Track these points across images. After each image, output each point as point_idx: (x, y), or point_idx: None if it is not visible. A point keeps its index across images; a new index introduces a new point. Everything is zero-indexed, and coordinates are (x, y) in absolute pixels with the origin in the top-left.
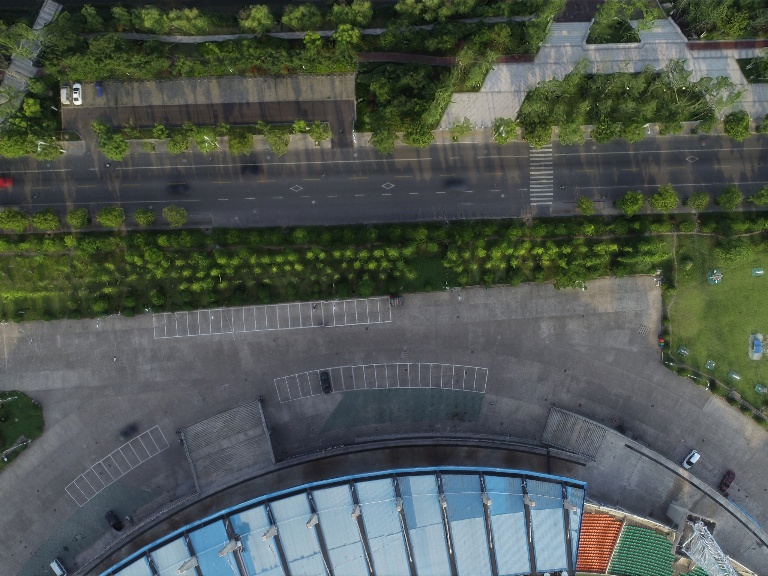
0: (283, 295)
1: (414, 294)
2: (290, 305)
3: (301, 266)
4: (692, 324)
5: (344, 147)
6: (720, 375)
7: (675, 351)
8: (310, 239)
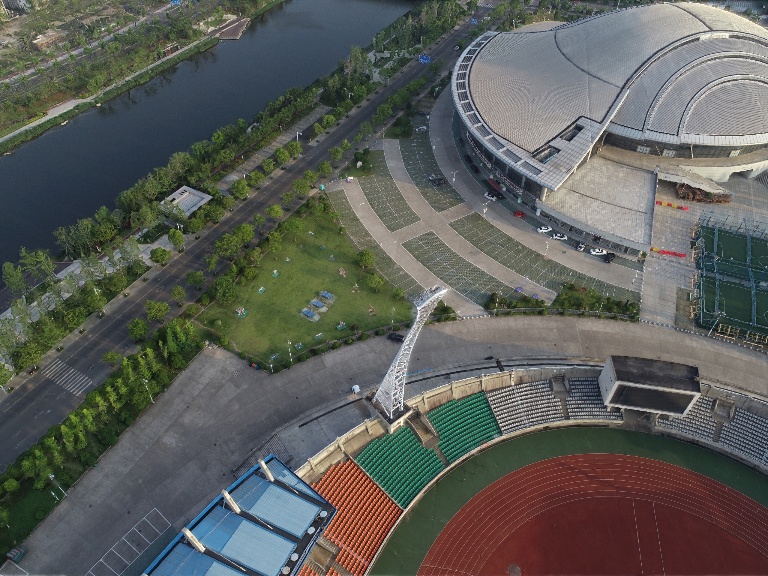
0: None
1: (32, 534)
2: None
3: None
4: (261, 342)
5: None
6: (311, 344)
7: None
8: None
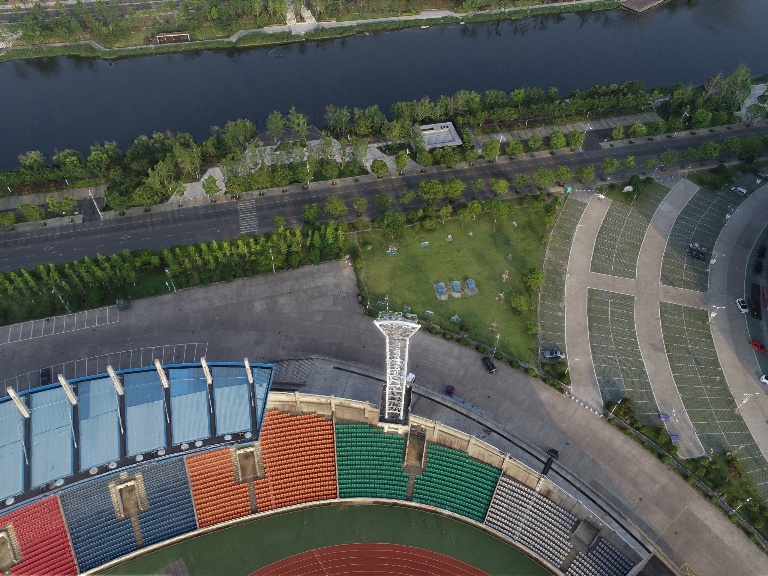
0: (19, 317)
1: (141, 300)
2: (24, 324)
3: (36, 285)
4: (383, 284)
5: (93, 221)
6: None
7: (374, 304)
8: (49, 269)
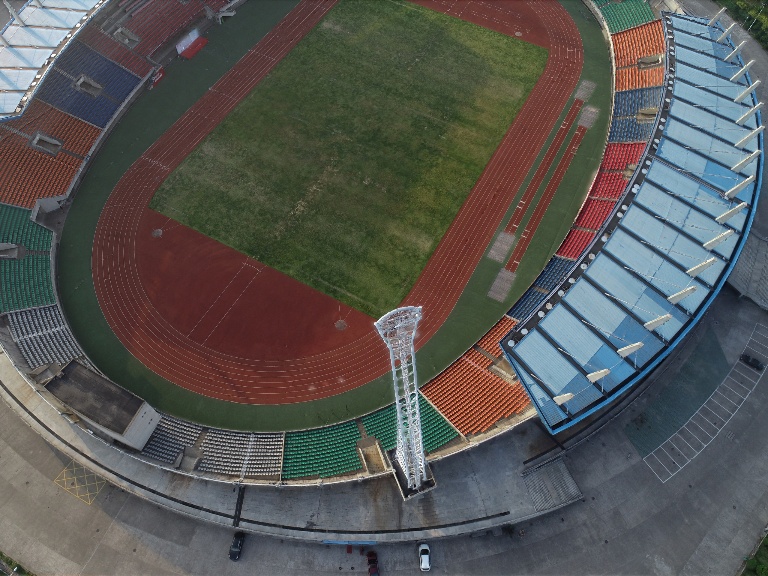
0: None
1: None
2: None
3: None
4: None
5: None
6: None
7: None
8: None
